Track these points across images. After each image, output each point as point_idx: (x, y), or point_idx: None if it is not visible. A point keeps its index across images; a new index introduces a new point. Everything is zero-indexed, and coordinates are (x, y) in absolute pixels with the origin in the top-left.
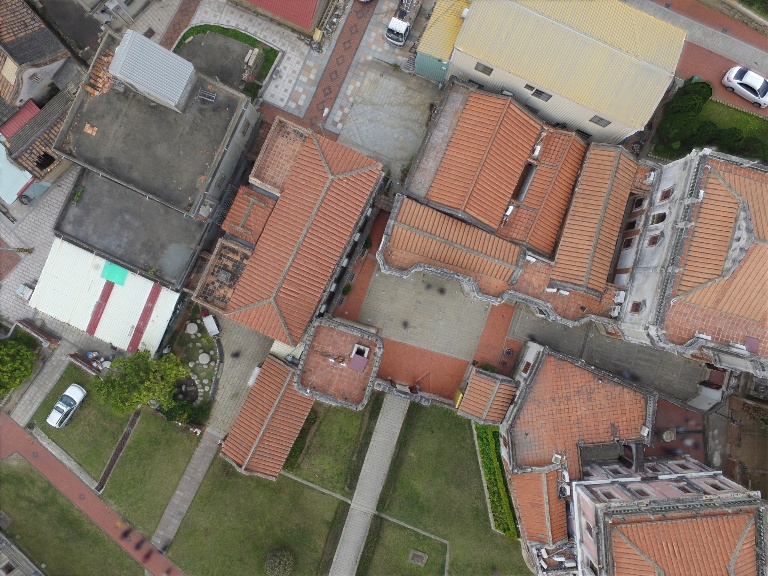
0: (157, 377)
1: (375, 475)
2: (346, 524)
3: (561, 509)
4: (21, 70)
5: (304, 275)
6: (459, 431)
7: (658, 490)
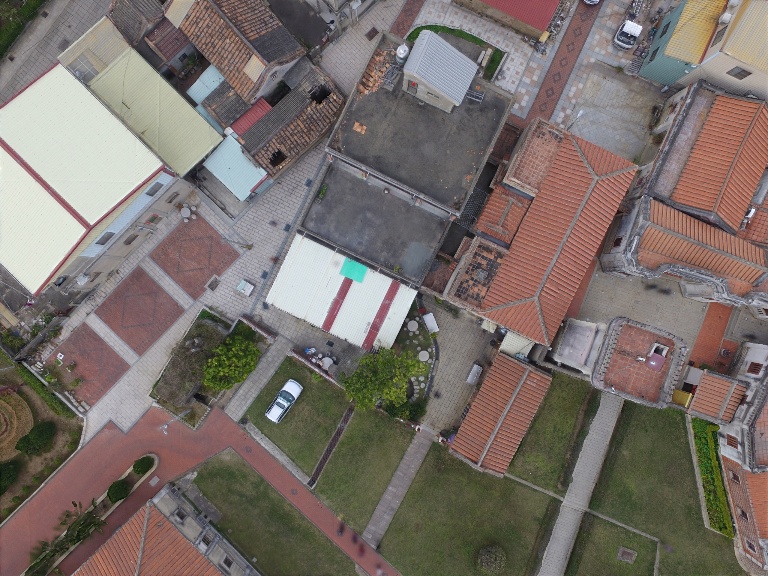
0: (401, 374)
1: (588, 473)
2: (557, 521)
3: None
4: (269, 68)
5: (563, 274)
6: (673, 430)
7: None
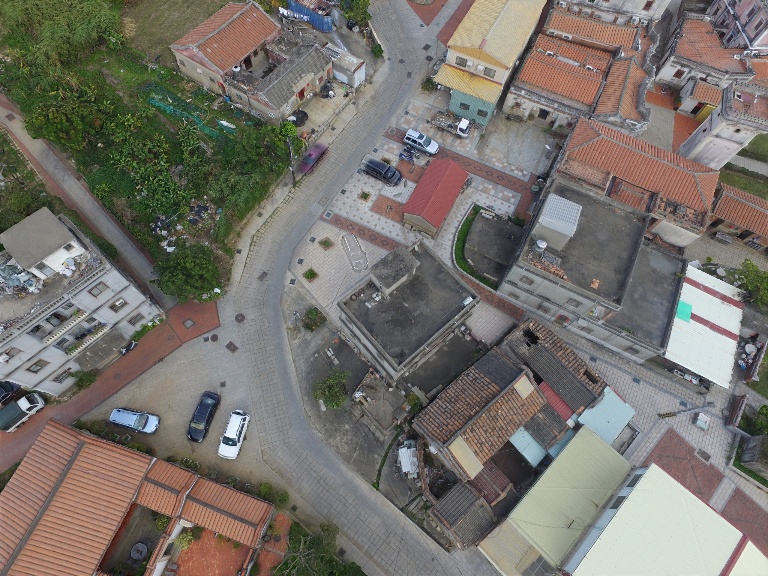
0: None
1: None
2: None
3: (767, 57)
4: (528, 370)
5: None
6: None
7: (746, 7)
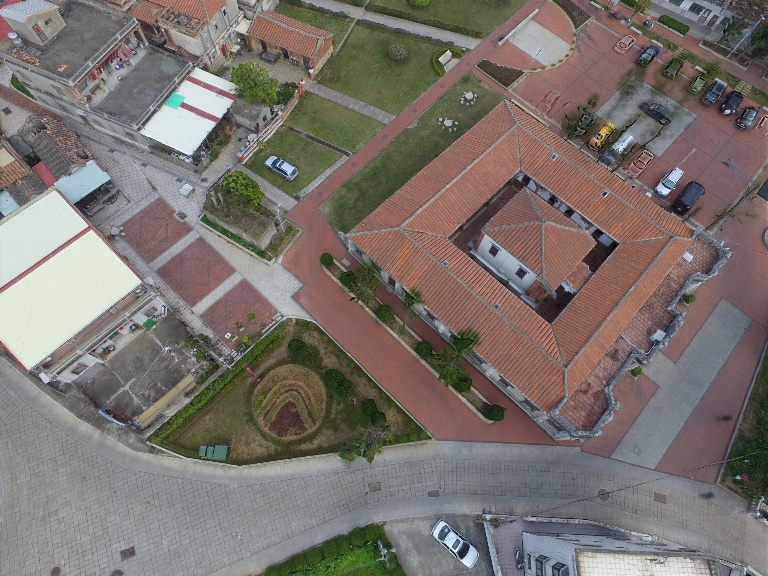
0: None
1: (339, 7)
2: None
3: None
4: (5, 143)
5: None
6: None
7: None
